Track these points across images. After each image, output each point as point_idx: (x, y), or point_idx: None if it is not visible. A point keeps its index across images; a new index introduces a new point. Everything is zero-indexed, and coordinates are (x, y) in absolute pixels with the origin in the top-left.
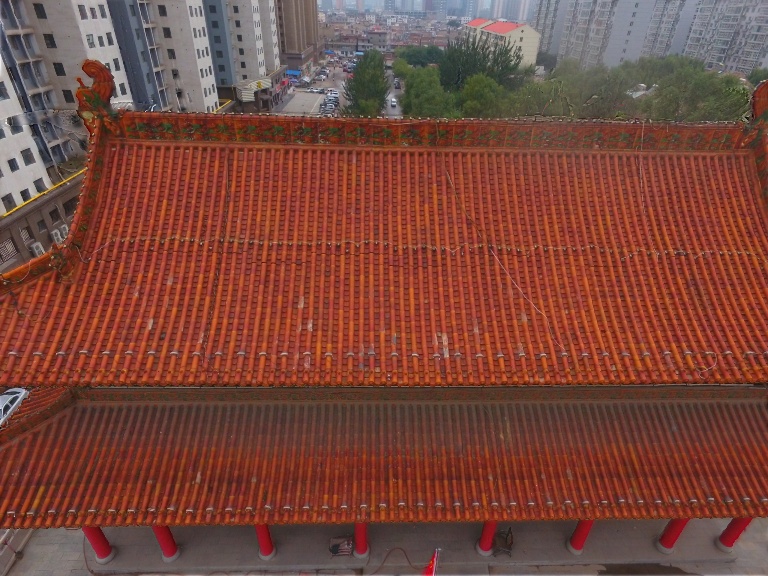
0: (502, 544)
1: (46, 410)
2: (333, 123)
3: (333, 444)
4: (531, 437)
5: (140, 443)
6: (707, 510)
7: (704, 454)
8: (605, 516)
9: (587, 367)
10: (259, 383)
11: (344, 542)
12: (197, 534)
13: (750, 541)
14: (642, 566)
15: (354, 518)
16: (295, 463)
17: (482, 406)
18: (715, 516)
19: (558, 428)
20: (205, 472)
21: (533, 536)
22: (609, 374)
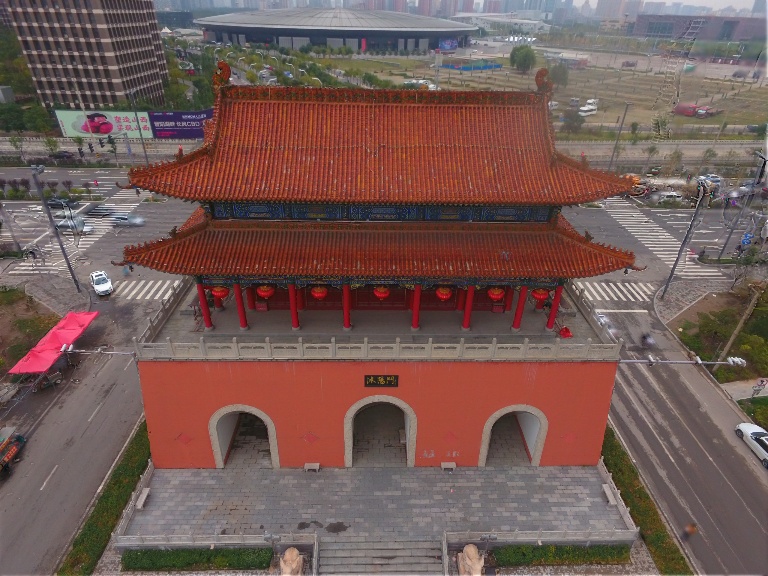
0: None
1: None
2: (436, 93)
3: None
4: None
5: None
6: None
7: None
8: None
9: None
10: None
11: None
12: None
13: None
14: None
15: None
16: None
17: None
18: None
19: None
20: None
21: None
22: None
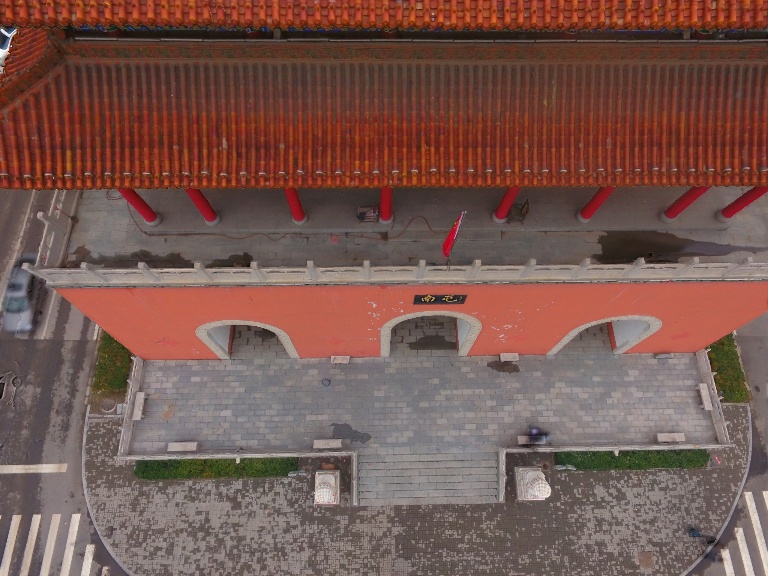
0: (517, 214)
1: (35, 67)
2: None
3: (361, 110)
4: (577, 104)
5: (153, 107)
6: (738, 178)
7: (759, 124)
8: (634, 183)
9: (681, 4)
10: (276, 23)
11: (370, 210)
12: (232, 203)
13: (748, 214)
14: (641, 233)
15: (386, 183)
16: (322, 130)
17: (529, 67)
18: (743, 184)
19: (609, 94)
20: (230, 138)
21: (546, 208)
22: (705, 14)
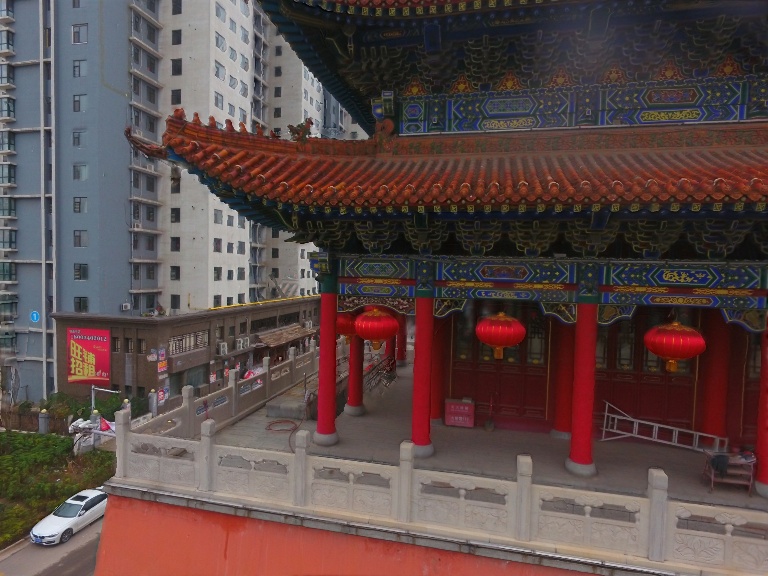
0: None
1: (351, 143)
2: None
3: None
4: None
5: (457, 171)
6: None
7: None
8: None
9: None
10: None
11: (735, 456)
12: (453, 444)
13: None
14: None
15: None
16: None
17: None
18: None
19: None
20: (557, 179)
21: None
22: None
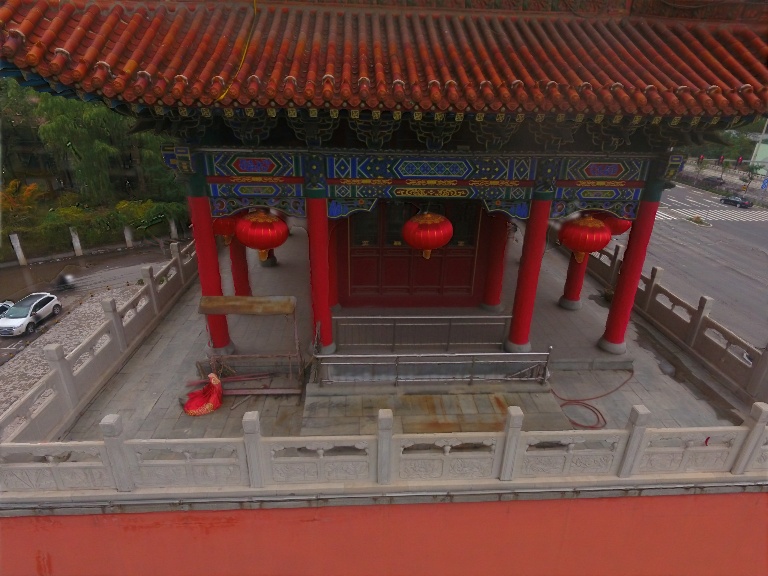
0: None
1: None
2: None
3: None
4: None
5: None
6: None
7: None
8: None
9: None
10: None
11: None
12: (536, 296)
13: None
14: None
15: None
16: None
17: None
18: None
19: None
20: None
21: None
22: None
